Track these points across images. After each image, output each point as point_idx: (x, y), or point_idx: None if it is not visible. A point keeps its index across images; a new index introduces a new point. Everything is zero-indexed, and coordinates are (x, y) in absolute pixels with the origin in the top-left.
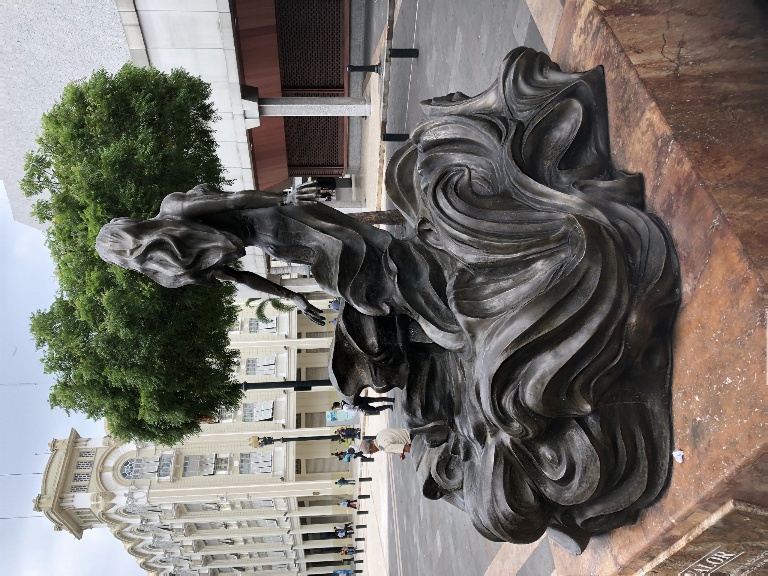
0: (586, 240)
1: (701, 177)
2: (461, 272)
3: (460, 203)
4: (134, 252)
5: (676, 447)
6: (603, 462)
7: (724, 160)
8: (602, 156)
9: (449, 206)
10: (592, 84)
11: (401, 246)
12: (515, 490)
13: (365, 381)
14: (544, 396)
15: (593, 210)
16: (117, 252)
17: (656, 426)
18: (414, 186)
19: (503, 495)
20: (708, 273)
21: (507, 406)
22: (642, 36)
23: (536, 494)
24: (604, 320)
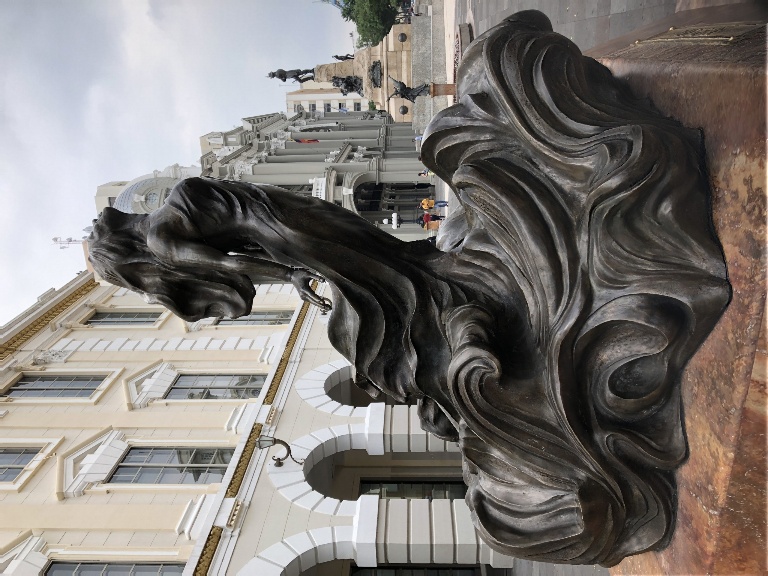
0: (584, 530)
1: (713, 569)
2: None
3: (482, 402)
4: None
5: None
6: None
7: (749, 565)
8: (672, 370)
9: (469, 401)
10: (701, 316)
11: (426, 315)
12: None
13: None
14: None
15: None
16: None
17: None
18: None
19: None
20: None
21: None
22: None
23: None
24: None
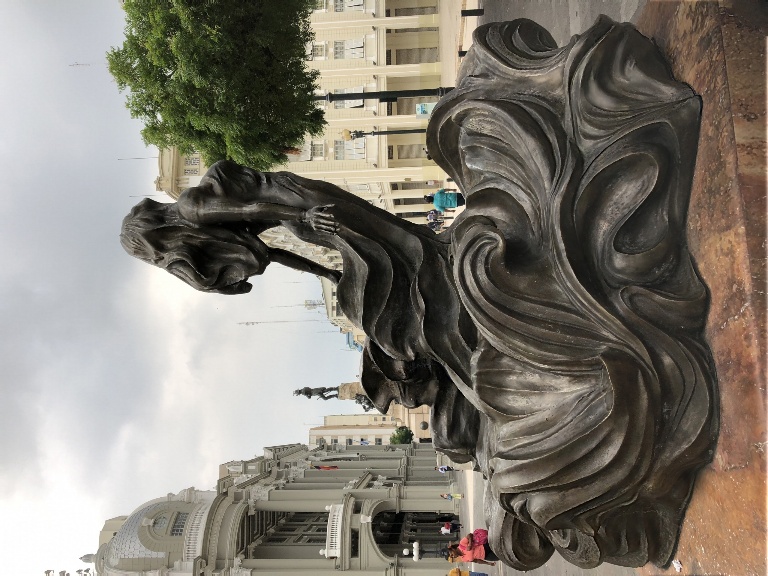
0: (615, 400)
1: (764, 378)
2: (487, 348)
3: (489, 286)
4: (158, 263)
5: (678, 555)
6: (604, 553)
7: None
8: (674, 226)
9: (476, 288)
10: (681, 130)
11: (433, 267)
12: (523, 535)
13: (395, 394)
14: (548, 523)
15: (636, 341)
16: (142, 259)
17: (664, 530)
18: (459, 153)
19: (510, 543)
20: (740, 478)
21: (514, 509)
22: (764, 84)
23: (542, 540)
24: (618, 484)
